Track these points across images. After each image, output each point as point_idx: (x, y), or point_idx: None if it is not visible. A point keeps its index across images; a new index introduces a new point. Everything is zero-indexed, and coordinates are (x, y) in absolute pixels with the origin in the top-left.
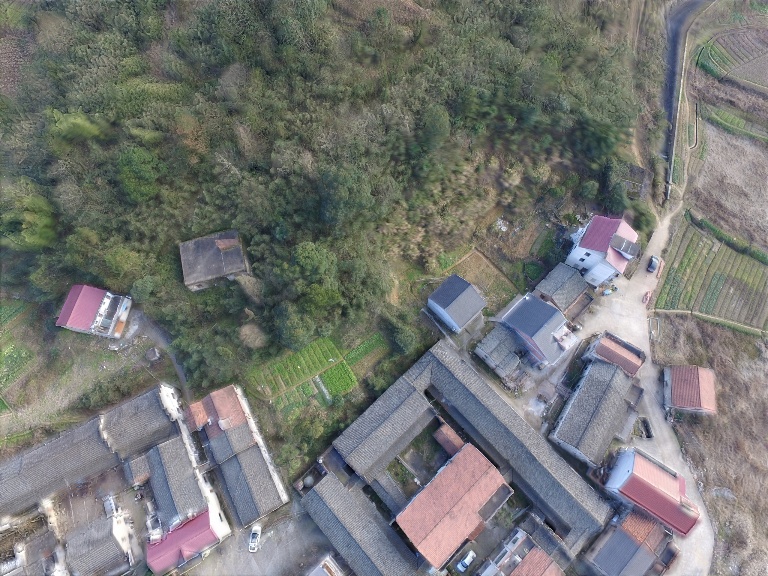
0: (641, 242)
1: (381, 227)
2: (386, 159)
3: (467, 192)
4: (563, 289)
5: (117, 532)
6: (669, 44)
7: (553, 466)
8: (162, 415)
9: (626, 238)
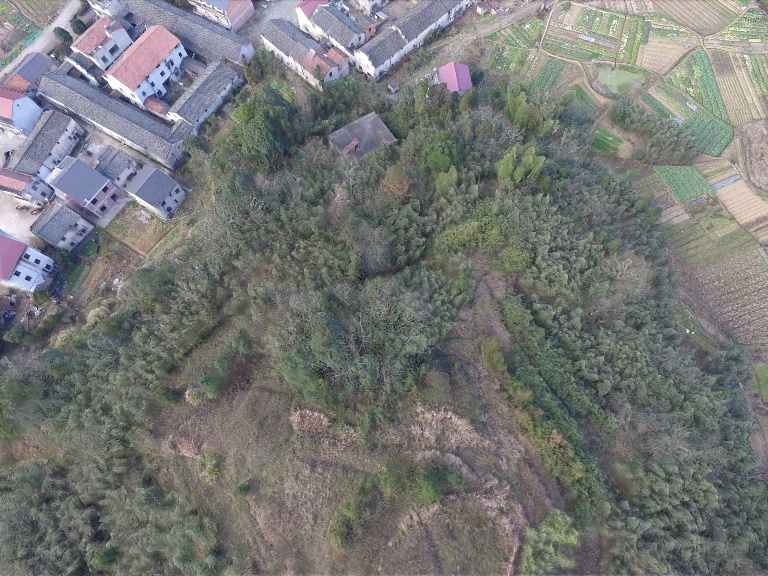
0: None
1: None
2: None
3: None
4: None
5: None
6: None
7: (75, 99)
8: None
9: None
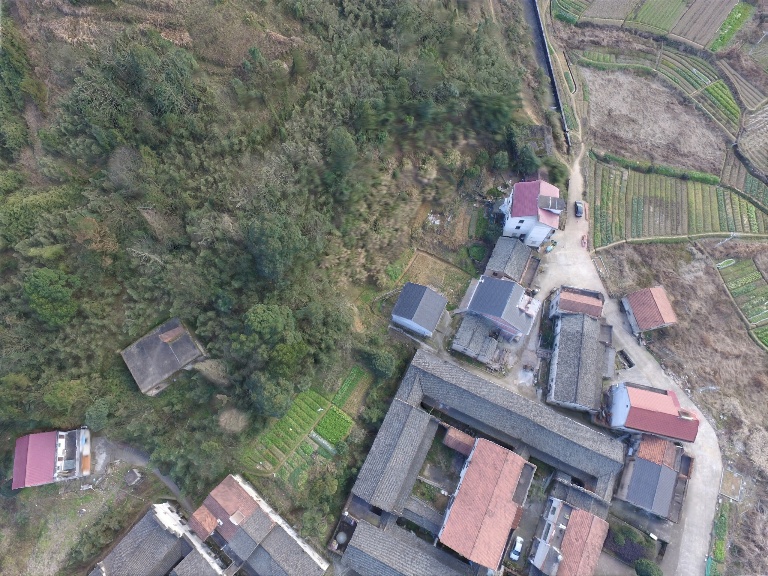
0: (562, 193)
1: (322, 262)
2: (304, 196)
3: (392, 200)
4: (511, 261)
5: None
6: (521, 5)
7: (562, 428)
8: (167, 535)
9: (550, 195)
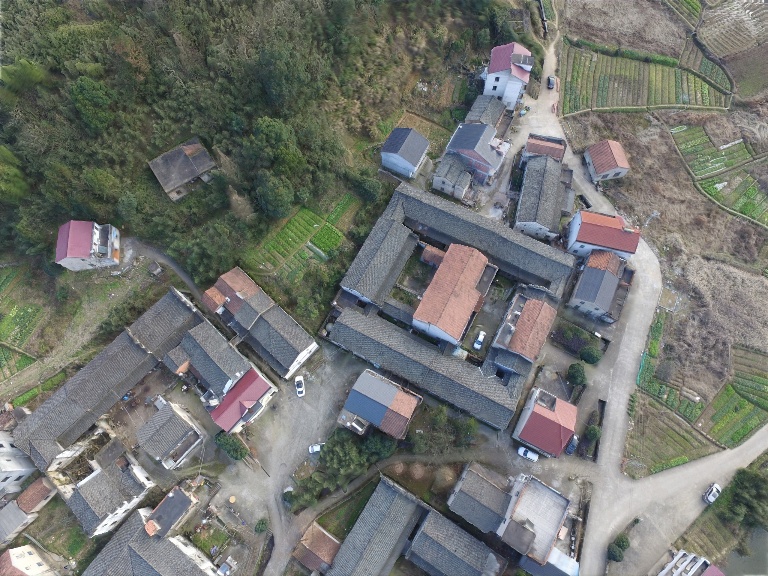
0: (536, 68)
1: (322, 105)
2: (308, 41)
3: (385, 62)
4: (487, 112)
5: (177, 411)
6: None
7: (522, 242)
8: (183, 308)
9: None
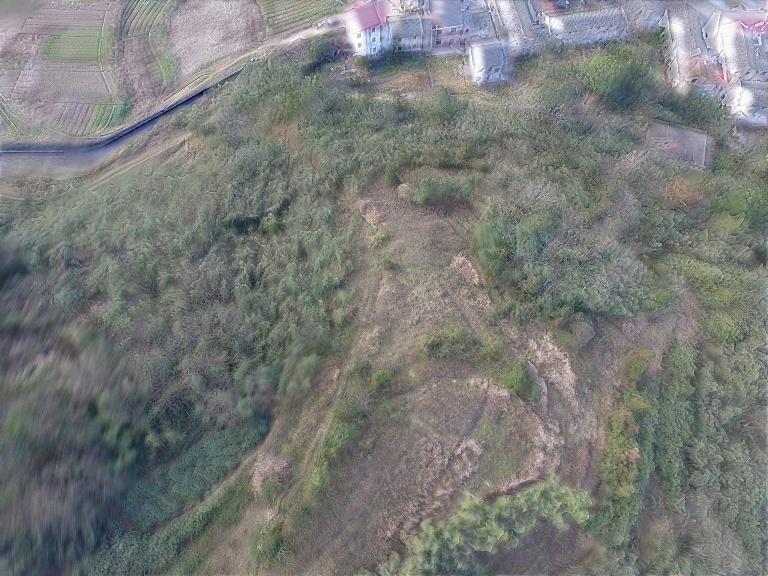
0: (318, 36)
1: None
2: None
3: None
4: None
5: None
6: None
7: None
8: None
9: (348, 6)
